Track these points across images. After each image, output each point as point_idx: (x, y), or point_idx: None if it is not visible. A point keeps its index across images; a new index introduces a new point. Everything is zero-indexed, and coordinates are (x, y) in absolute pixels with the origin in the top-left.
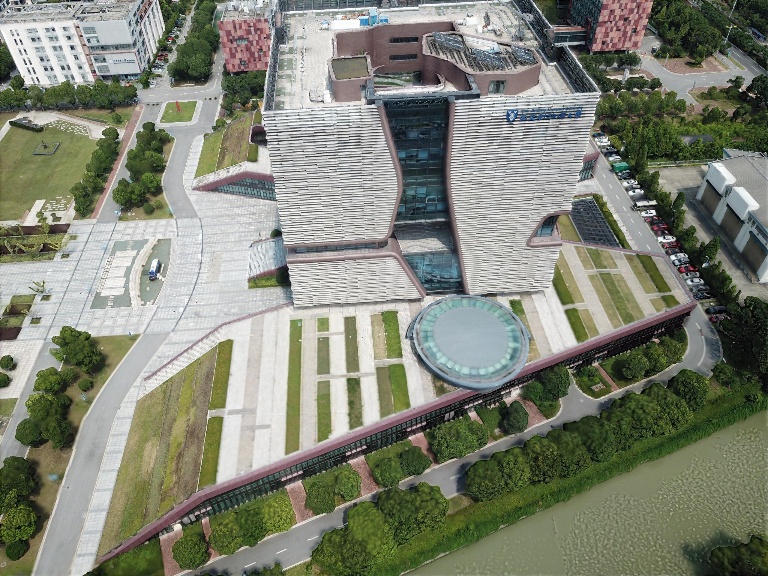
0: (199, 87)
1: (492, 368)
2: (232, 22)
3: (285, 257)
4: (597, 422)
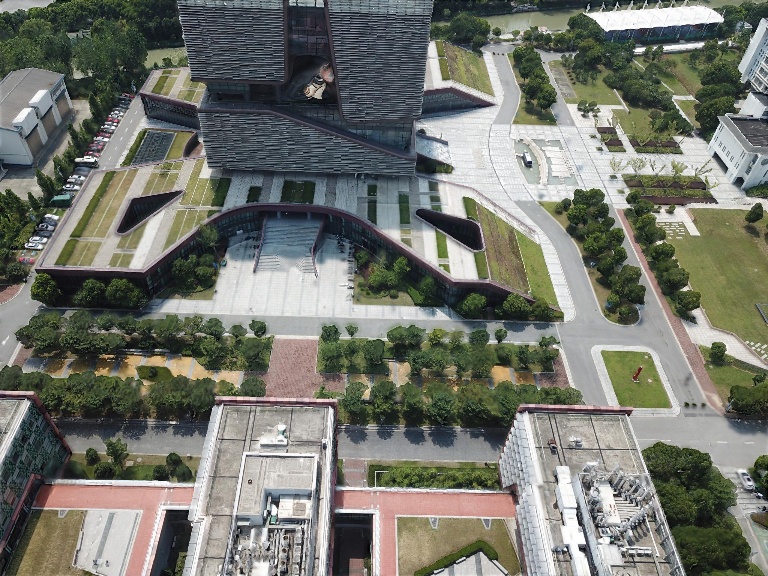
0: None
1: None
2: None
3: (420, 143)
4: None
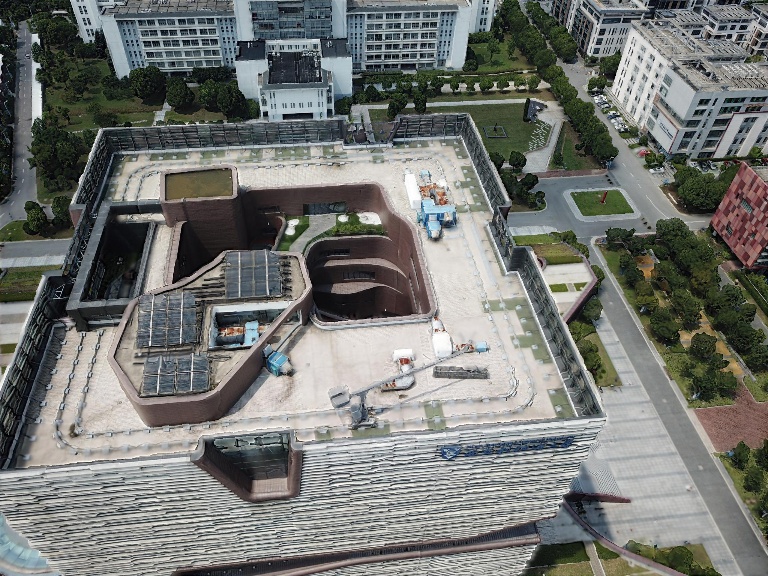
0: (673, 209)
1: (1, 524)
2: (754, 176)
3: None
4: None
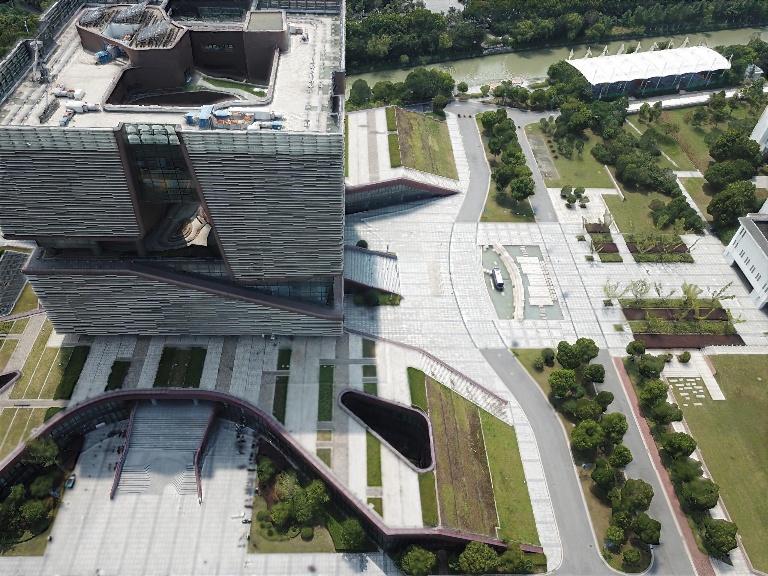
0: None
1: None
2: None
3: (360, 262)
4: None
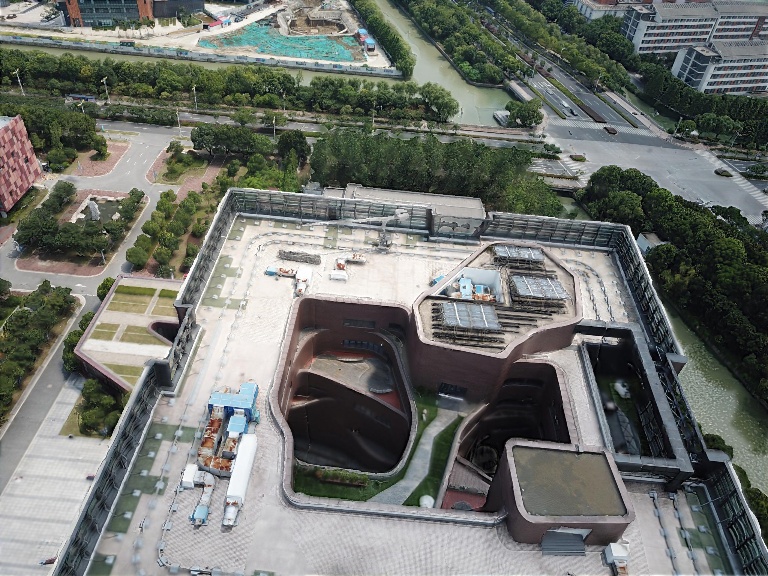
0: None
1: None
2: None
3: None
4: (708, 442)
